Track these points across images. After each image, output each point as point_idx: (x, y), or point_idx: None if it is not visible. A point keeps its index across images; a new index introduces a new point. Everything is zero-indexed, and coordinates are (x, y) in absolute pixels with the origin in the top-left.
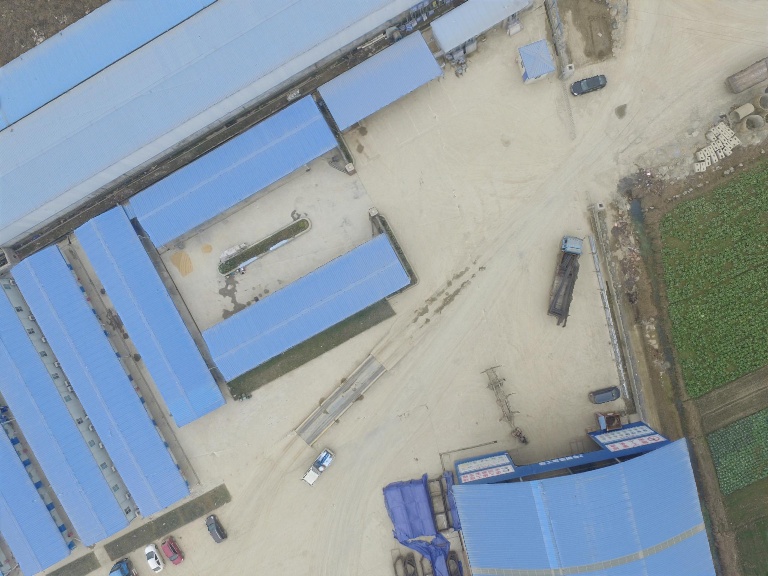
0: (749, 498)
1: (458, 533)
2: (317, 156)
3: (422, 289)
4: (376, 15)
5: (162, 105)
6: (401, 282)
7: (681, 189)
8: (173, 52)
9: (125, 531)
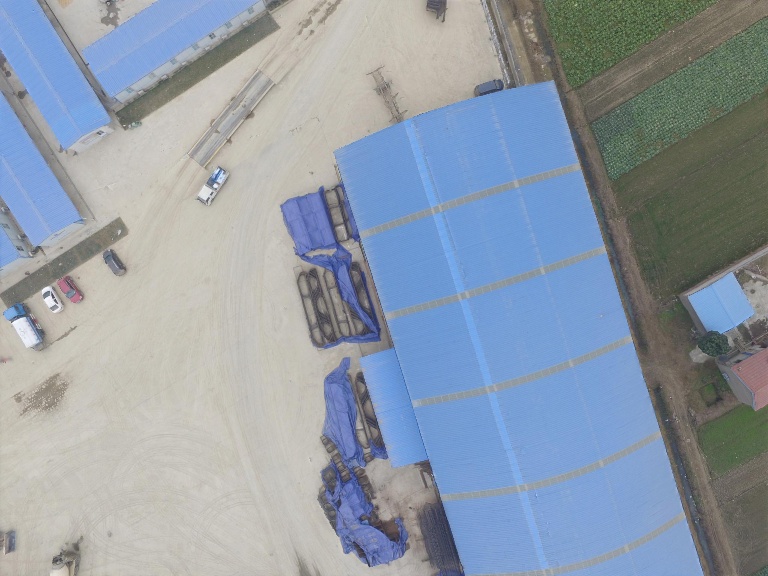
0: (636, 181)
1: (359, 244)
2: None
3: (304, 1)
4: None
5: None
6: None
7: None
8: None
9: (20, 277)
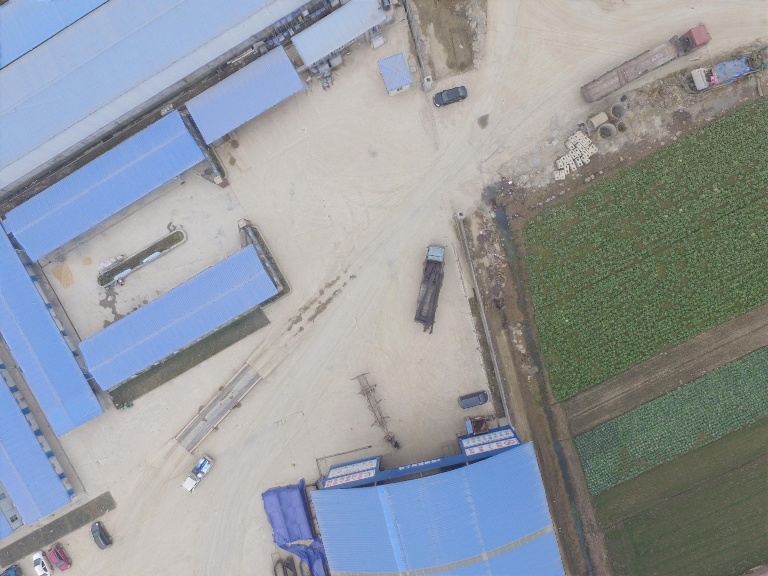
0: (617, 499)
1: None
2: (185, 170)
3: (295, 298)
4: (235, 31)
5: (27, 122)
6: (269, 292)
7: (543, 197)
8: (37, 71)
9: (14, 539)
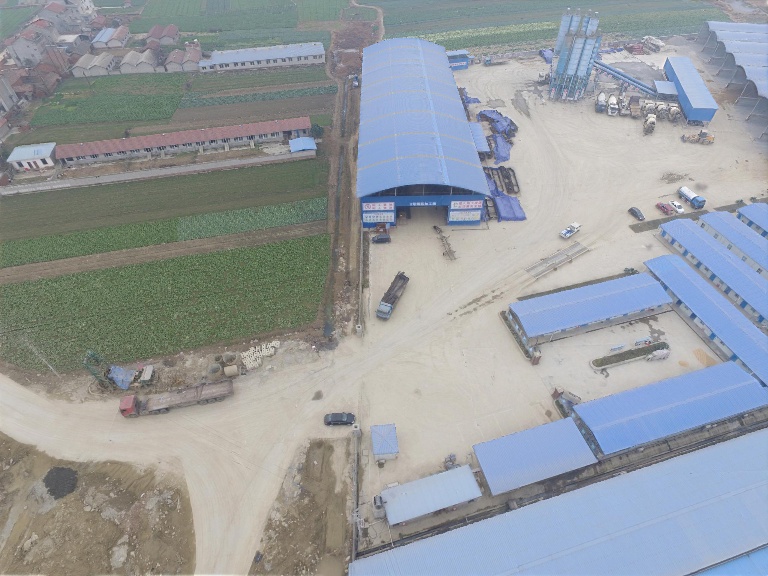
0: (314, 194)
1: None
2: (592, 401)
3: (496, 309)
4: None
5: (765, 457)
6: (516, 305)
7: None
8: None
9: None
